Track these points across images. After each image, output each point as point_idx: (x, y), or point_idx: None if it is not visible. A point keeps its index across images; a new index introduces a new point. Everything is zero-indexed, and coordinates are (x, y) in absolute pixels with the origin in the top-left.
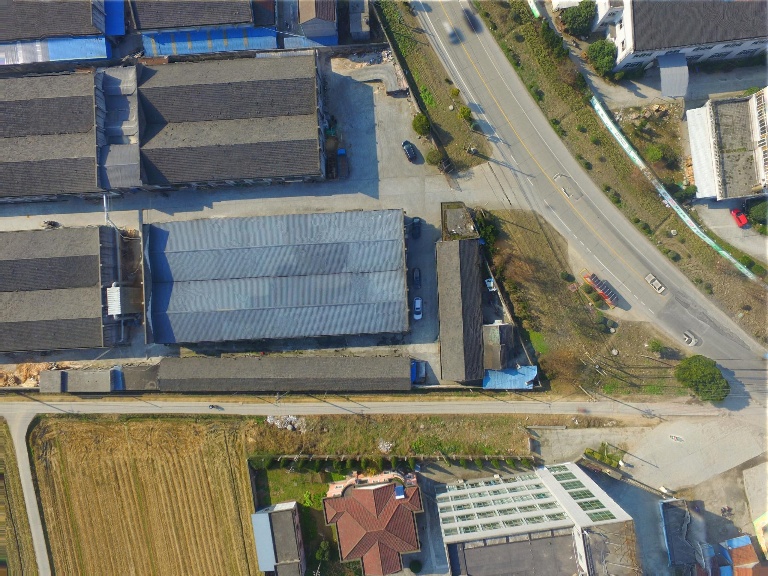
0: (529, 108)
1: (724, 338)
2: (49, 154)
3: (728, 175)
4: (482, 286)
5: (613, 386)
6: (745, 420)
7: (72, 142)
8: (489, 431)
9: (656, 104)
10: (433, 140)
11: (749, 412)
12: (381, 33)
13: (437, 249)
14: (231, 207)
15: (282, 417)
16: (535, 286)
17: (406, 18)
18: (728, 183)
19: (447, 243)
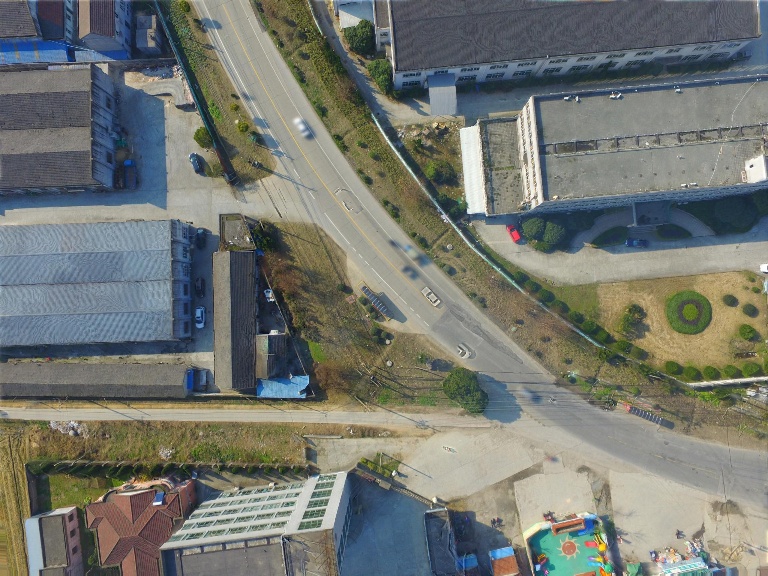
0: (313, 124)
1: (497, 351)
2: None
3: (496, 192)
4: (263, 296)
5: (387, 397)
6: (516, 432)
7: None
8: (267, 439)
9: (436, 122)
10: (216, 153)
11: (520, 424)
12: None
13: (213, 259)
14: (23, 215)
15: (64, 422)
16: (314, 297)
17: (197, 34)
18: (496, 200)
19: (221, 254)
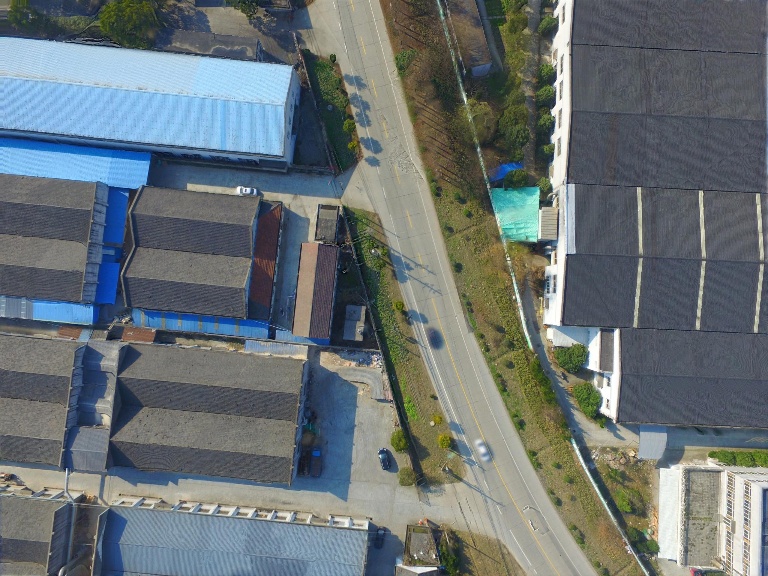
0: (509, 435)
1: None
2: (15, 428)
3: (691, 542)
4: None
5: None
6: None
7: (42, 414)
8: None
9: (633, 450)
10: (409, 457)
11: None
12: (374, 335)
13: (396, 573)
14: (197, 487)
15: None
16: None
17: (401, 326)
18: (690, 551)
19: (407, 572)
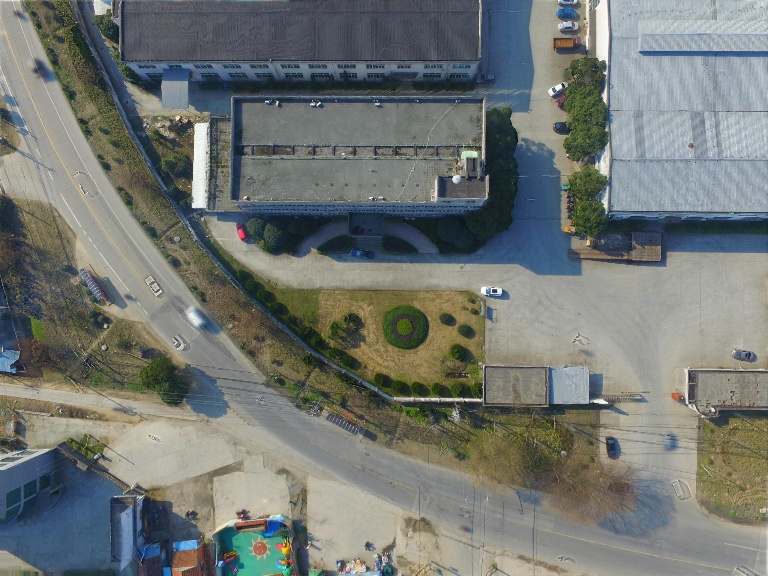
0: (61, 106)
1: (212, 346)
2: None
3: (219, 189)
4: None
5: (99, 380)
6: (221, 428)
7: None
8: None
9: None
10: None
11: (226, 421)
12: None
13: None
14: None
15: None
16: (41, 275)
17: None
18: (218, 197)
19: None
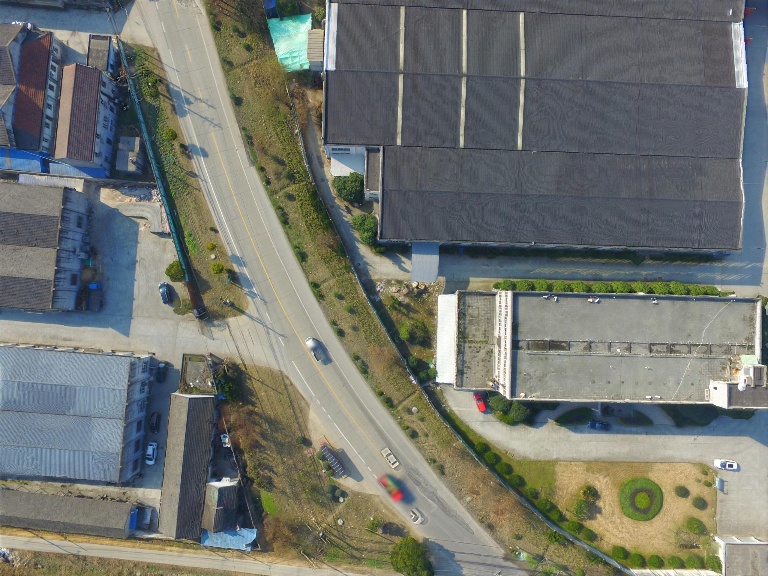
0: (291, 268)
1: (450, 519)
2: None
3: (467, 365)
4: (219, 440)
5: (335, 555)
6: None
7: None
8: None
9: (416, 281)
10: (187, 288)
11: None
12: None
13: (171, 401)
14: None
15: None
16: (272, 446)
17: (181, 160)
18: (465, 373)
19: (179, 398)
